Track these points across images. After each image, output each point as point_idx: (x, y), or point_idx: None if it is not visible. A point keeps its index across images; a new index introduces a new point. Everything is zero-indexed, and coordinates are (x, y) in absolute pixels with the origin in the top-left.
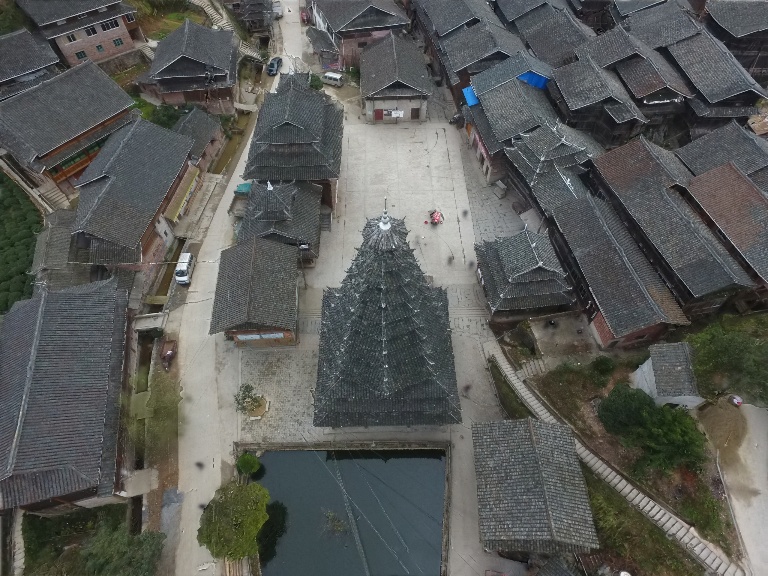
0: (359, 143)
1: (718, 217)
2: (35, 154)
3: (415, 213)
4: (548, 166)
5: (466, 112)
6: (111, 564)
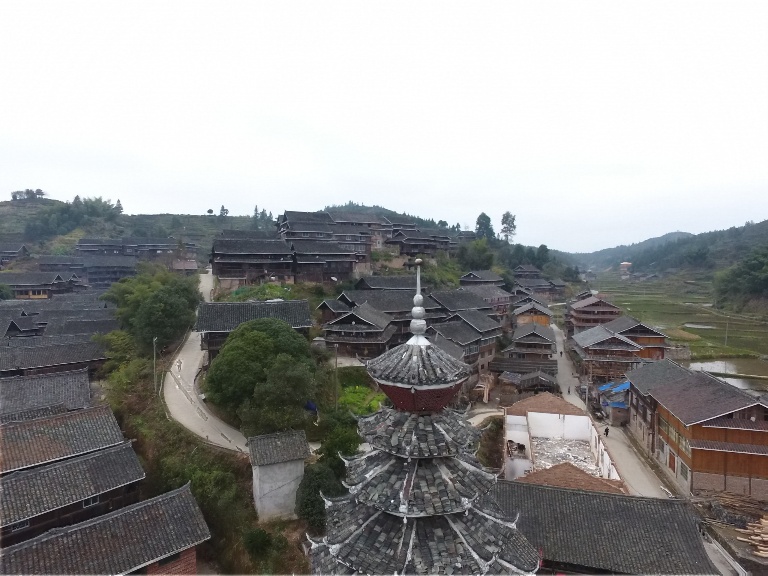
0: None
1: (2, 466)
2: None
3: None
4: None
5: None
6: None
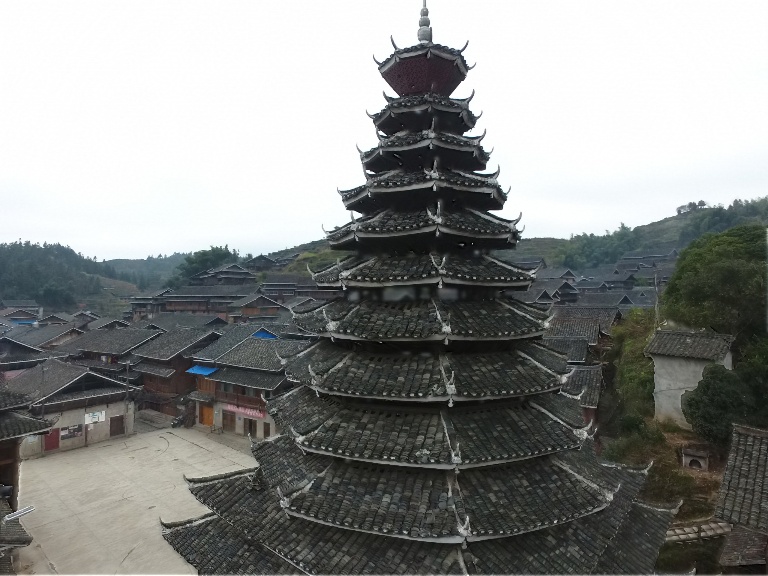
0: (23, 478)
1: None
2: None
3: None
4: None
5: (198, 395)
6: None
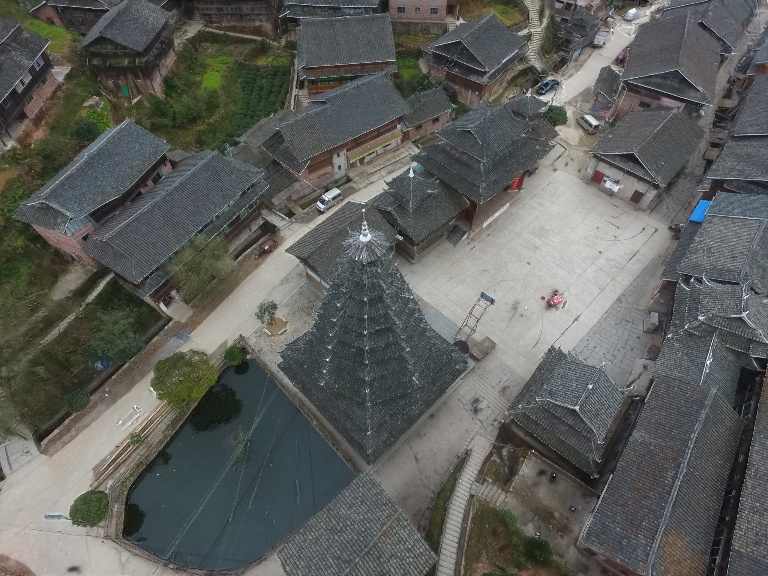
0: (556, 192)
1: None
2: (304, 64)
3: (542, 283)
4: (705, 331)
5: None
6: (102, 333)
